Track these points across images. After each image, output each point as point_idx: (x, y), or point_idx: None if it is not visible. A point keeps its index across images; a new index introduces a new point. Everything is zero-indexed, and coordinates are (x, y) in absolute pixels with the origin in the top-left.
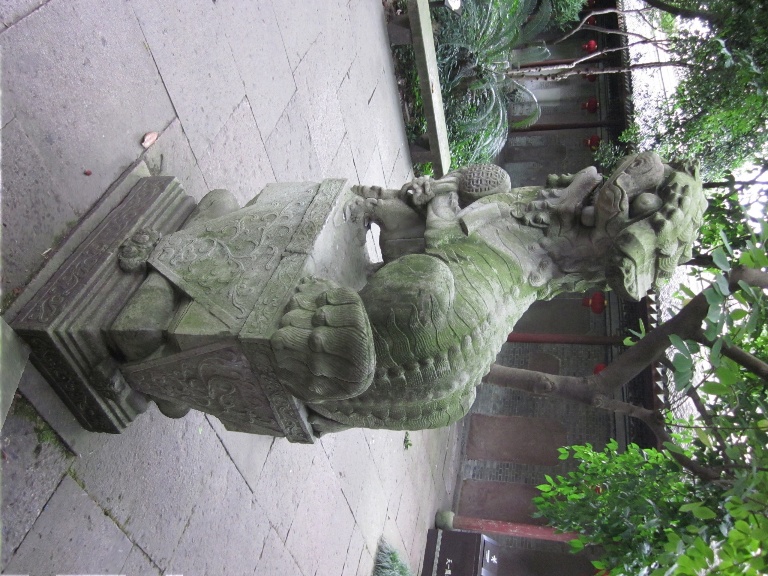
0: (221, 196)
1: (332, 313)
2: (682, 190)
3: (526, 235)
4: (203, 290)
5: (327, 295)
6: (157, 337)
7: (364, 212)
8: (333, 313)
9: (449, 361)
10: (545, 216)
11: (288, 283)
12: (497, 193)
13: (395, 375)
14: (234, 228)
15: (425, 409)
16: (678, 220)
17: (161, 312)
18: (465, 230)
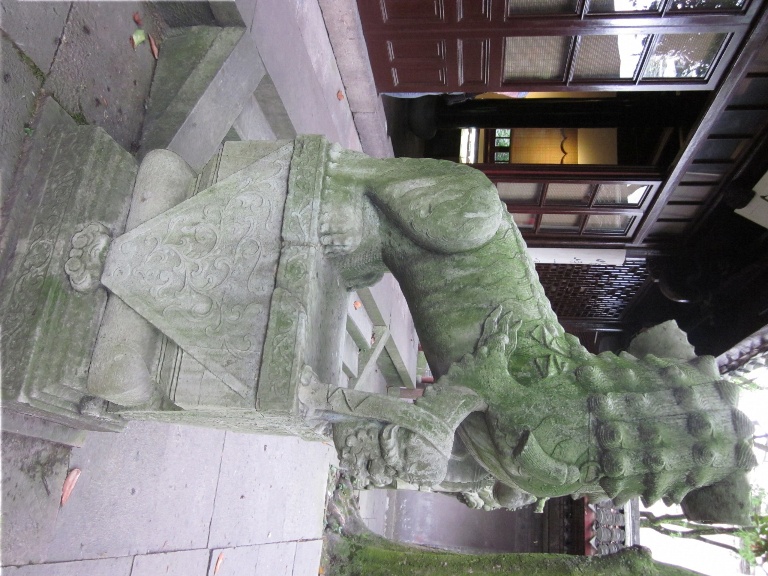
0: None
1: None
2: None
3: None
4: None
5: None
6: None
7: None
8: None
9: None
10: None
11: None
12: None
13: None
14: None
15: None
16: None
17: None
18: None
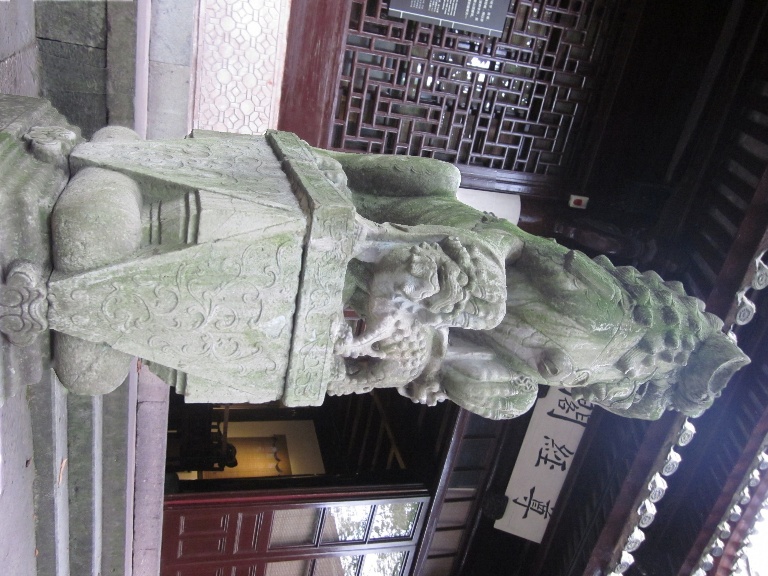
0: None
1: None
2: None
3: None
4: None
5: None
6: None
7: (344, 357)
8: None
9: None
10: None
11: None
12: None
13: None
14: None
15: None
16: None
17: None
18: None
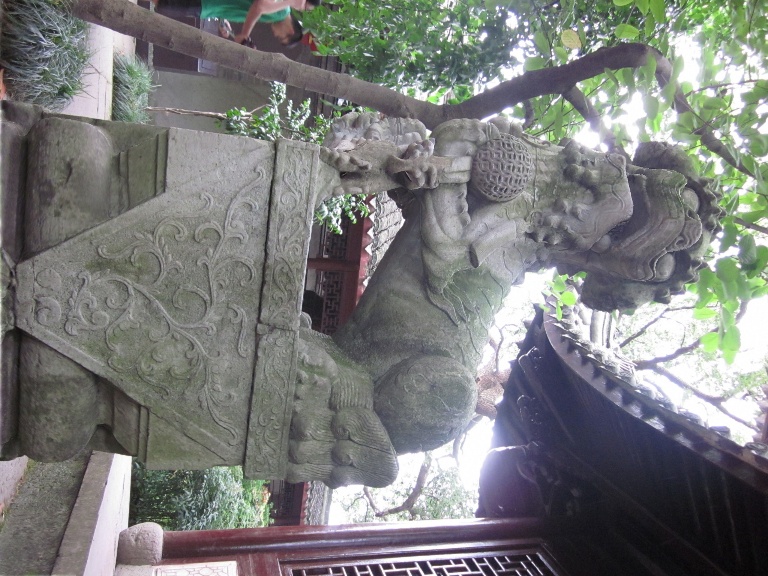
0: (80, 146)
1: (359, 457)
2: (699, 268)
3: (528, 248)
4: (154, 391)
5: (350, 433)
6: (93, 433)
7: None
8: (361, 457)
9: None
10: (558, 240)
11: (283, 389)
12: (516, 197)
13: None
14: (151, 255)
15: None
16: None
17: (90, 410)
18: (475, 264)
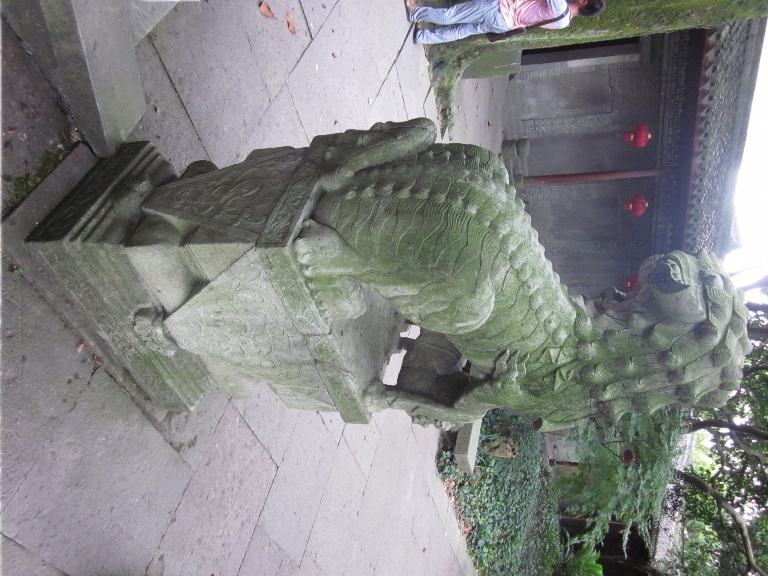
0: None
1: None
2: None
3: None
4: None
5: None
6: None
7: None
8: None
9: (493, 176)
10: None
11: None
12: None
13: (441, 153)
14: None
15: (453, 190)
16: (716, 261)
17: None
18: None
